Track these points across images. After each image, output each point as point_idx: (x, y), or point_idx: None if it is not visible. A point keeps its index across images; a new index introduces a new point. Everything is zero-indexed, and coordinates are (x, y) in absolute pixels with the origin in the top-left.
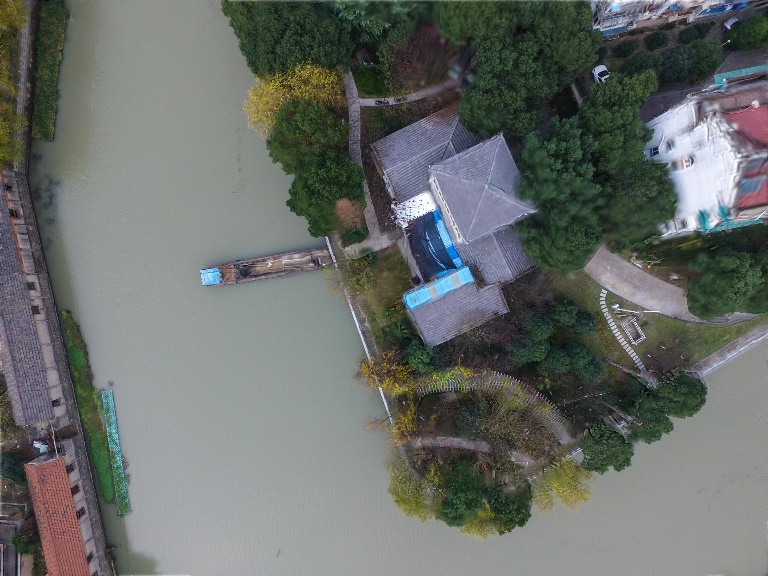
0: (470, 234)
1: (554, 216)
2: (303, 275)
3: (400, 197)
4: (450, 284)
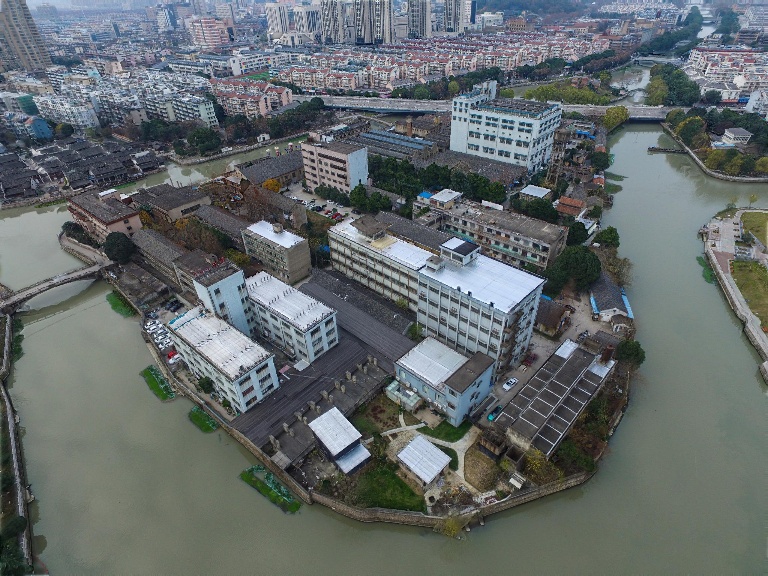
0: None
1: None
2: (677, 153)
3: (713, 140)
4: None
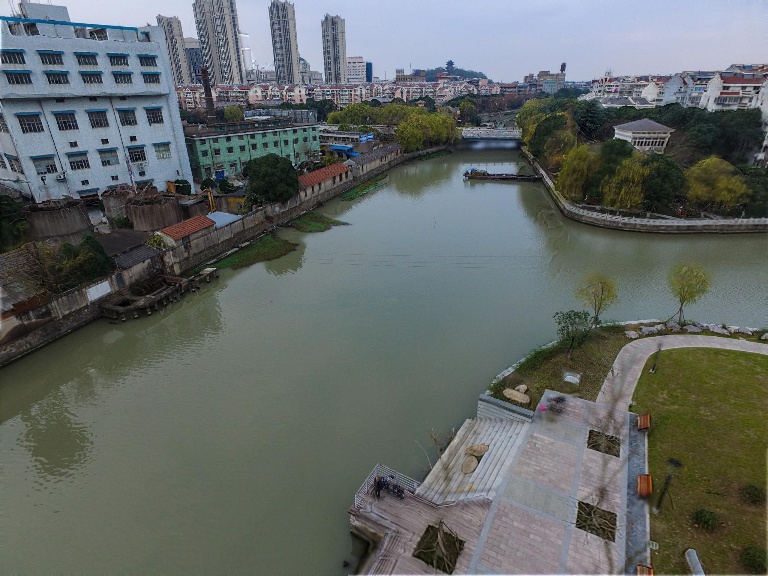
0: None
1: None
2: (521, 181)
3: None
4: None
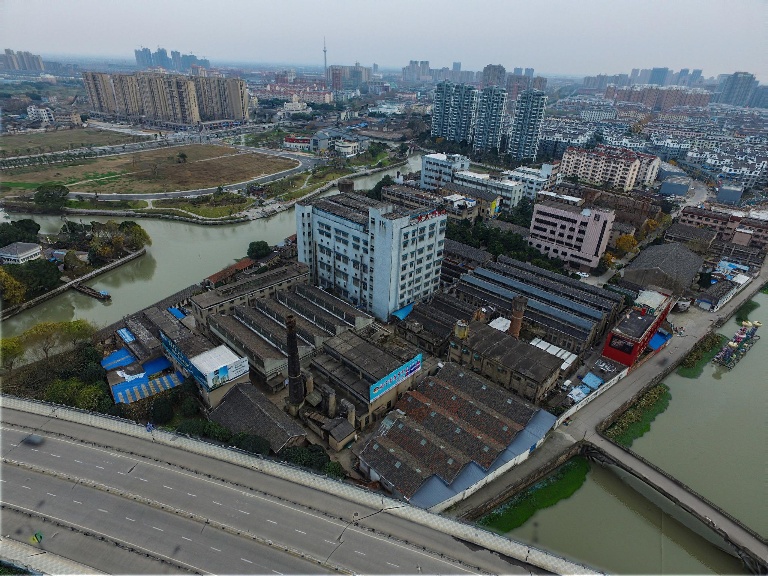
0: (37, 244)
1: (20, 238)
2: None
3: None
4: (61, 252)
